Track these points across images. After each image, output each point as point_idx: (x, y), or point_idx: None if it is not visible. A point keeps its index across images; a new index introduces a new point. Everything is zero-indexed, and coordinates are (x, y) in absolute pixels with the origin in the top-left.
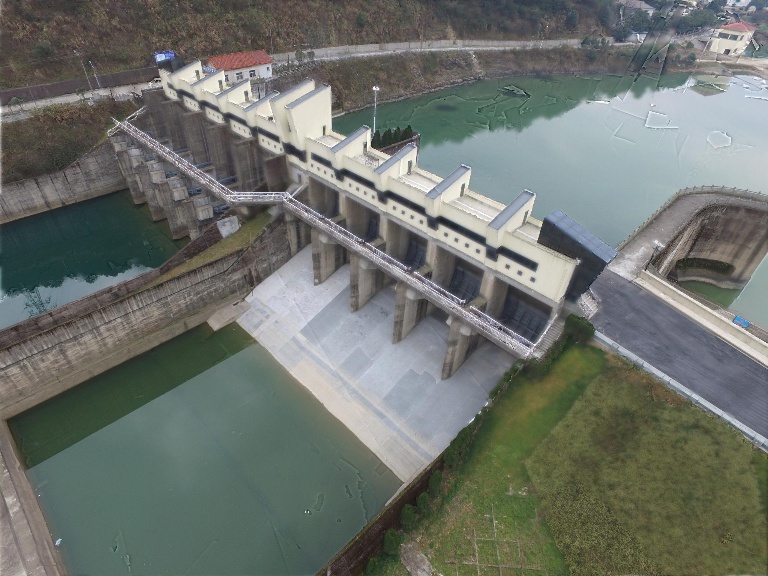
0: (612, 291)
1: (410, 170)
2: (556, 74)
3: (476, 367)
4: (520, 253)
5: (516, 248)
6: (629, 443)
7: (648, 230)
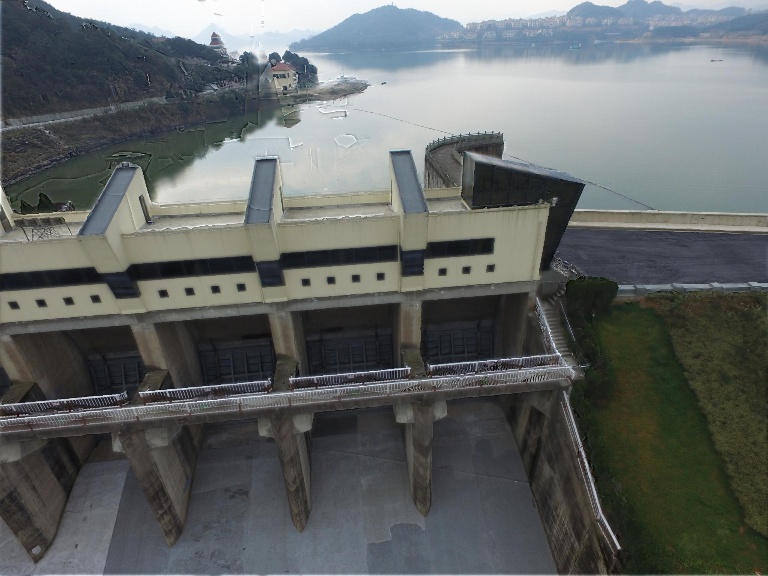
0: None
1: (147, 215)
2: (158, 133)
3: (445, 455)
4: (459, 237)
5: (450, 233)
6: None
7: None
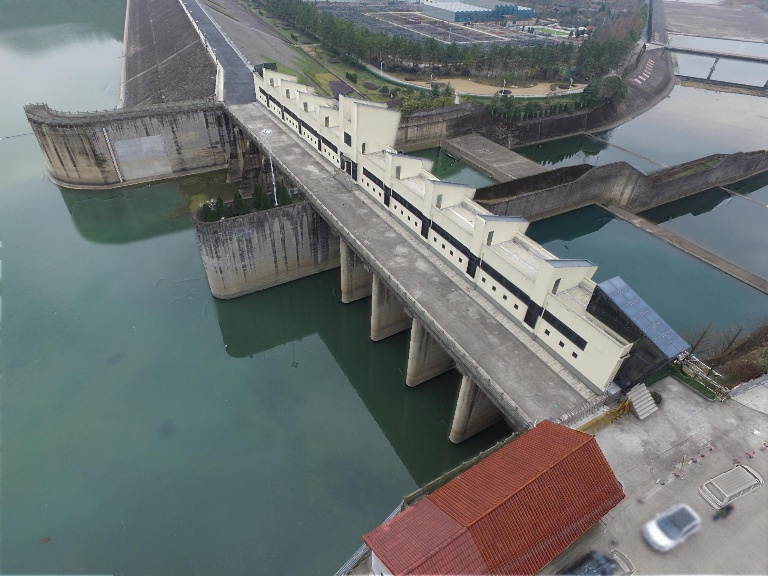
0: None
1: None
2: None
3: None
4: None
5: None
6: None
7: None
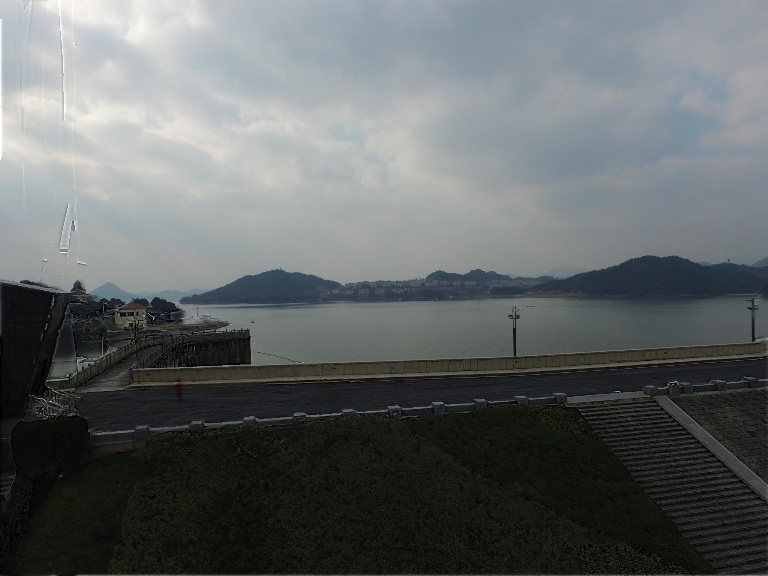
0: (98, 402)
1: None
2: None
3: None
4: None
5: None
6: (266, 543)
7: (120, 364)
